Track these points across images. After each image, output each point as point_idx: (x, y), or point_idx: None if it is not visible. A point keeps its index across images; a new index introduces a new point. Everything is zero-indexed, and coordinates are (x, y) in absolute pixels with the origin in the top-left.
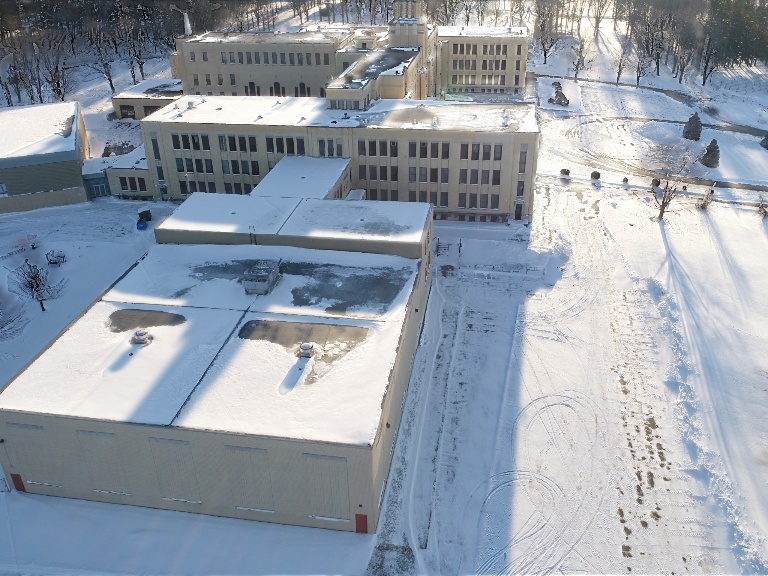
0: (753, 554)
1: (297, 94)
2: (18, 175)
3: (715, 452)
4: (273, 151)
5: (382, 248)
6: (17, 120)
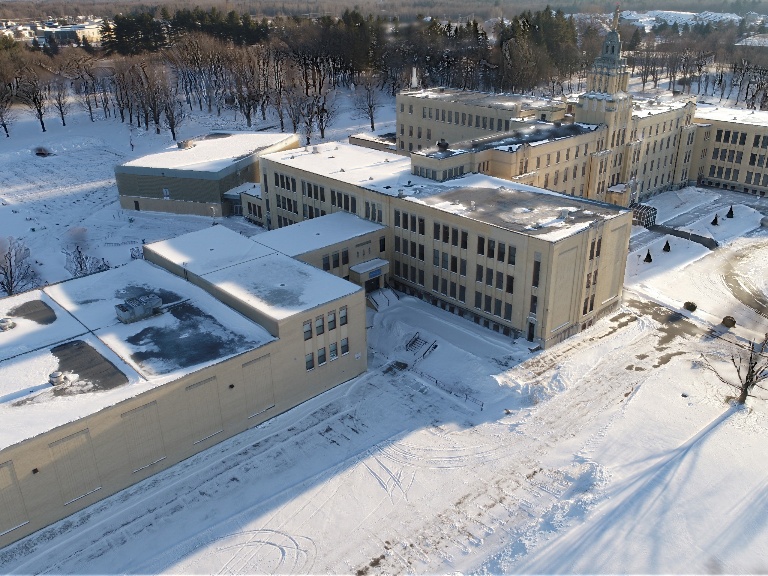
0: None
1: None
2: (178, 184)
3: None
4: (336, 204)
5: (255, 316)
6: (234, 142)
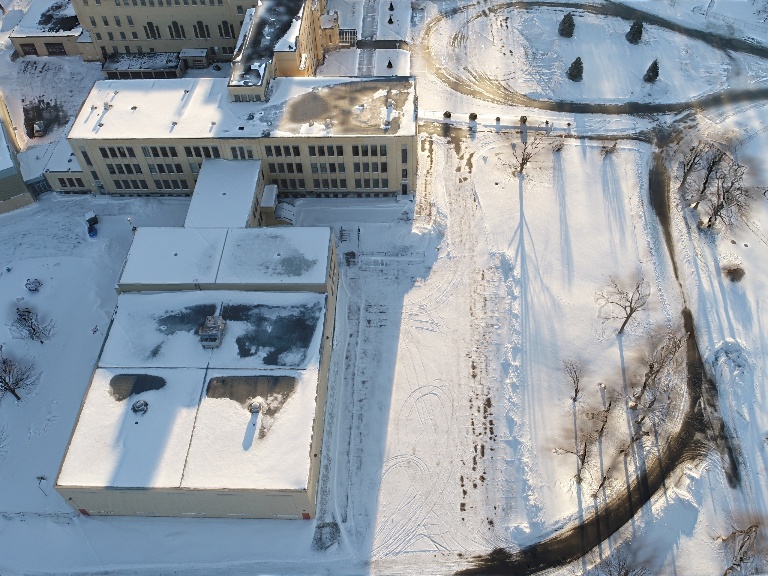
0: (534, 500)
1: (196, 31)
2: None
3: (526, 421)
4: (192, 156)
5: (297, 288)
6: None
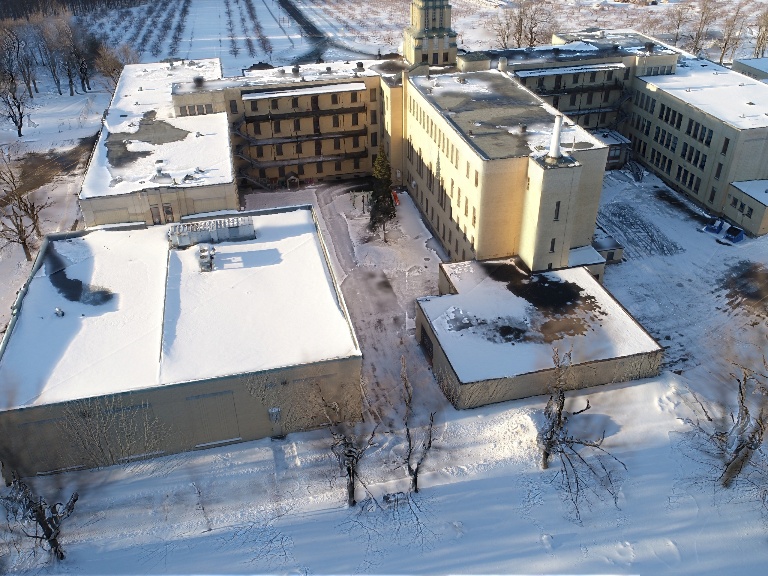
0: None
1: None
2: None
3: None
4: None
5: None
6: None
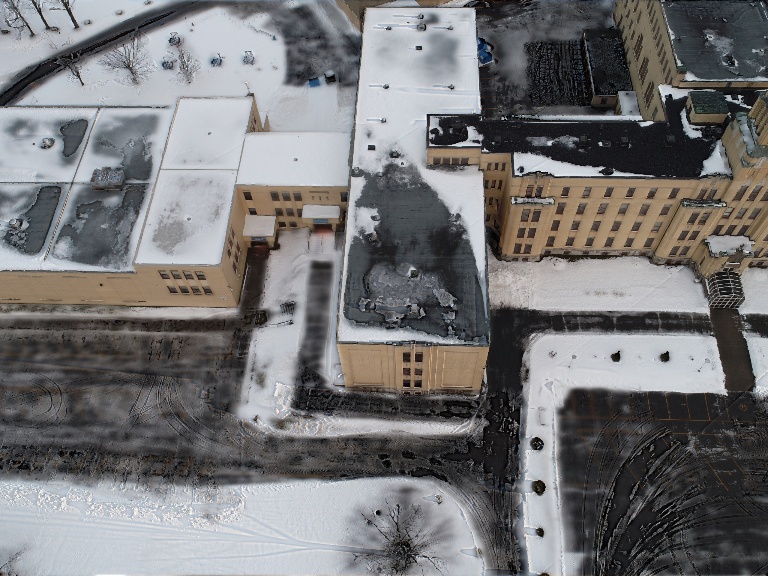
0: None
1: None
2: None
3: None
4: None
5: None
6: None
